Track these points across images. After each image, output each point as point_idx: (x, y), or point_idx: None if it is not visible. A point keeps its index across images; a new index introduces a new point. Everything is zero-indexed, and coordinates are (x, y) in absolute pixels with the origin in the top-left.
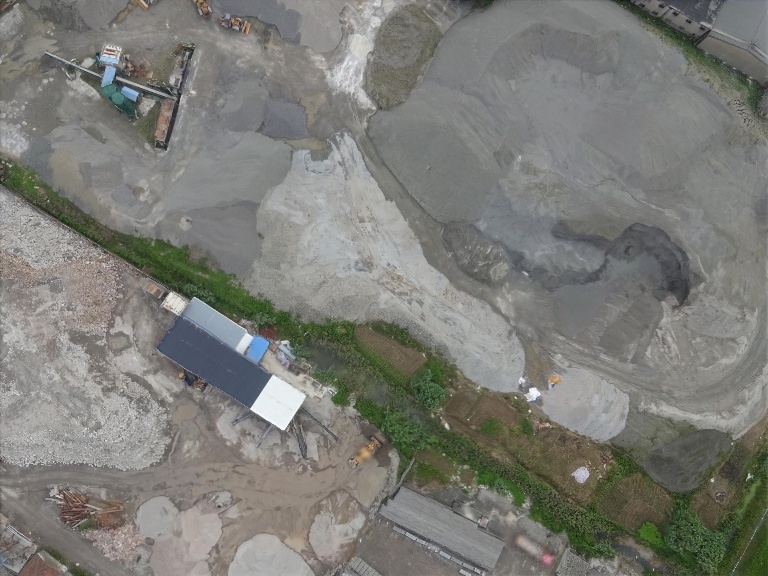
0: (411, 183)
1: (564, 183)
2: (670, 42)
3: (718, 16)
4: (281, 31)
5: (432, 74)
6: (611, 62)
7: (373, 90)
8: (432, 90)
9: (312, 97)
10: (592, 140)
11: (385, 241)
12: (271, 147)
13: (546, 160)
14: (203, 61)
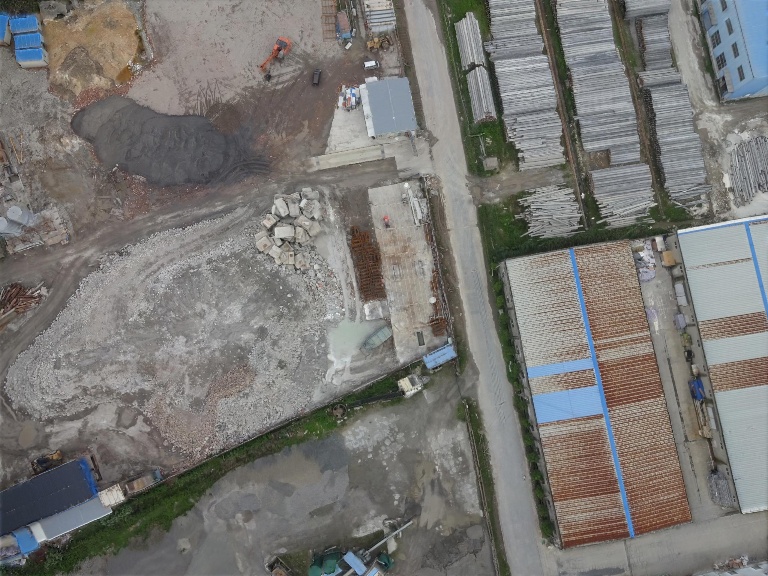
0: None
1: None
2: None
3: None
4: None
5: None
6: None
7: None
8: None
9: None
10: None
11: None
12: None
13: None
14: None
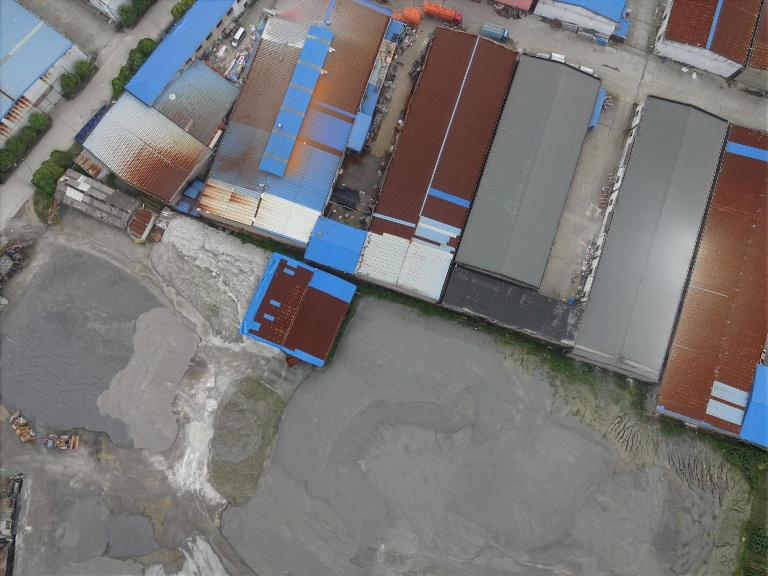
0: None
1: (436, 565)
2: (533, 364)
3: (579, 329)
4: (112, 438)
5: (278, 457)
6: (466, 418)
7: (217, 489)
8: (278, 482)
9: (156, 503)
10: (459, 509)
11: None
12: (118, 575)
13: (412, 543)
14: (34, 491)
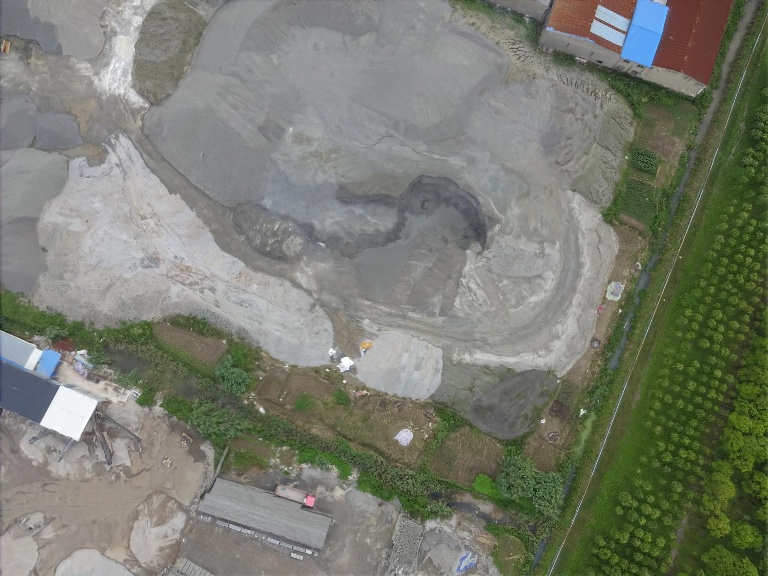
0: (192, 173)
1: (340, 147)
2: None
3: None
4: (42, 45)
5: (198, 62)
6: (371, 21)
7: (140, 87)
8: (196, 78)
9: (82, 104)
10: (363, 101)
11: (169, 234)
12: (43, 160)
13: (318, 128)
14: None
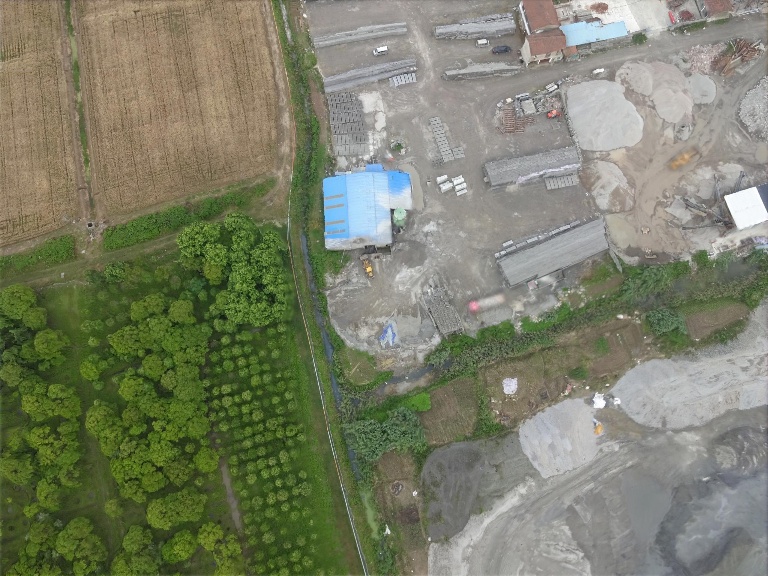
0: None
1: None
2: None
3: None
4: None
5: None
6: None
7: None
8: None
9: None
10: None
11: None
12: None
13: None
14: None
